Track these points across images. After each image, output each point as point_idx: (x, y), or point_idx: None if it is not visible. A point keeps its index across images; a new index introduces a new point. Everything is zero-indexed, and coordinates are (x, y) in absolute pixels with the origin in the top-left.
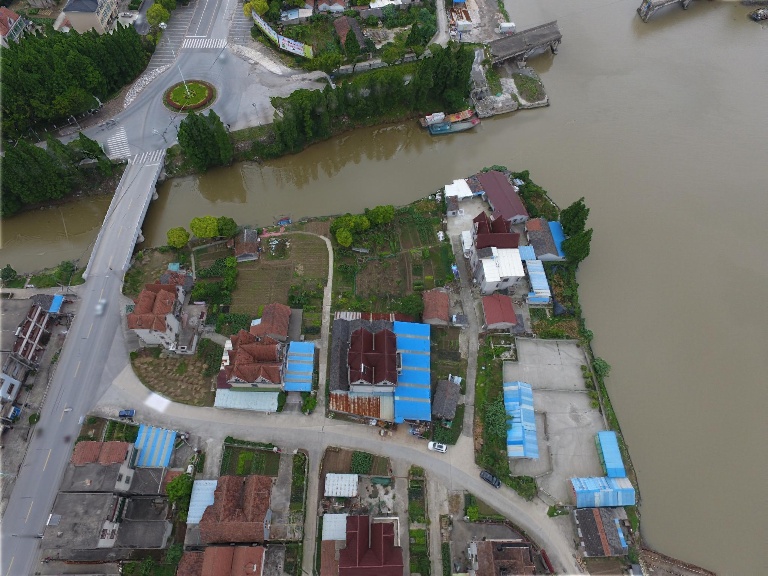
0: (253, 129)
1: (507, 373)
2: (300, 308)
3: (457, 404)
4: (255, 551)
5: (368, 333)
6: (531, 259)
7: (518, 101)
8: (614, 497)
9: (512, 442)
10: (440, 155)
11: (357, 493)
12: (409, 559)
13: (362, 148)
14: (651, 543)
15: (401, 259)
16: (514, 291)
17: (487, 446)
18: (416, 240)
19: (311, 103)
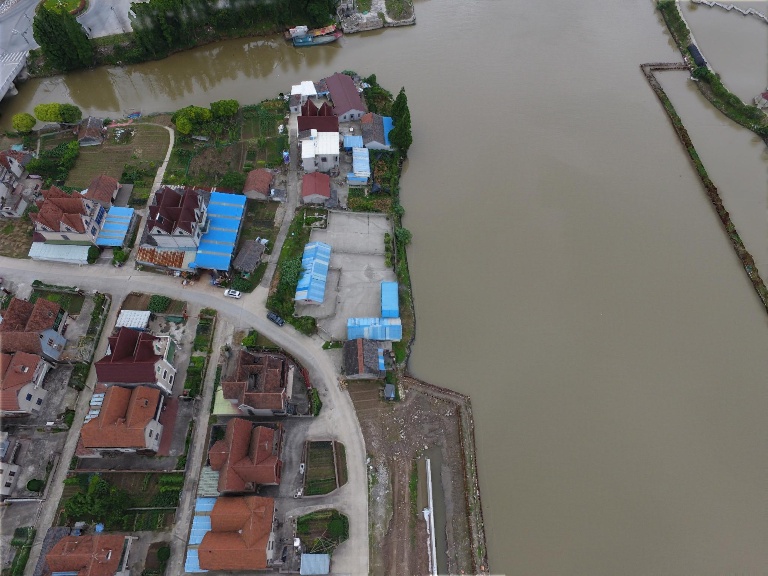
0: (118, 36)
1: (314, 239)
2: (131, 184)
3: (261, 262)
4: (29, 357)
5: (175, 193)
6: (358, 147)
7: (384, 19)
8: (382, 332)
9: (300, 289)
10: (305, 68)
11: (149, 328)
12: (185, 378)
13: (238, 64)
14: (415, 373)
15: (237, 146)
16: (335, 172)
17: (279, 294)
18: (257, 132)
19: (168, 8)
